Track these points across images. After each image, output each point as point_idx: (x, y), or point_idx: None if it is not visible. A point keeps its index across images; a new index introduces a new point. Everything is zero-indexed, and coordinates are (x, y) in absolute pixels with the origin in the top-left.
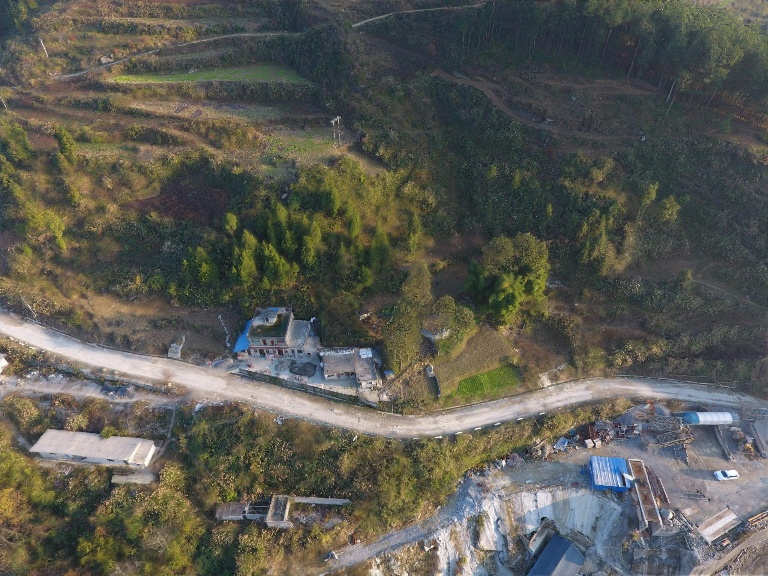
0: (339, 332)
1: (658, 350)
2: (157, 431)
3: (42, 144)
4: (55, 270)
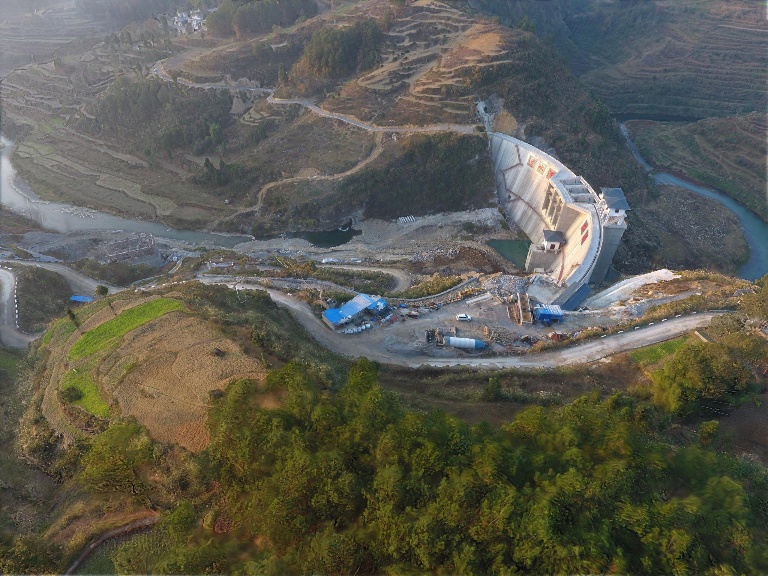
0: None
1: None
2: None
3: None
4: None
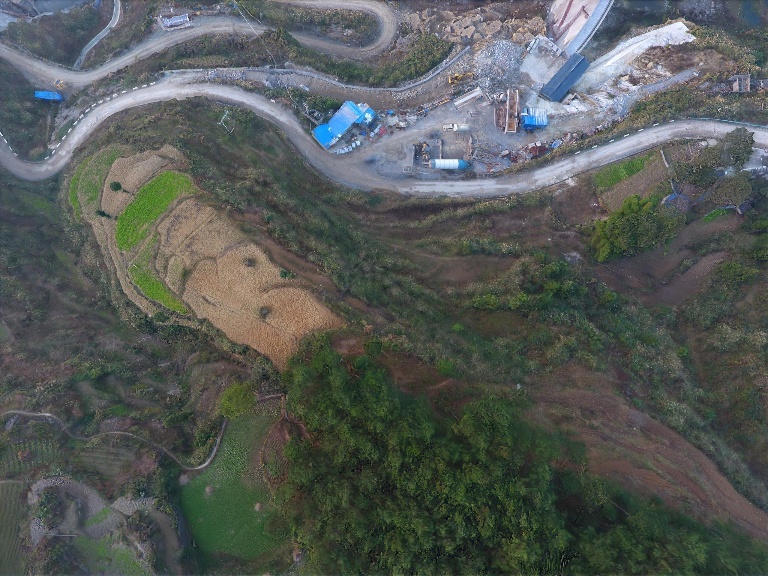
0: (760, 183)
1: (483, 204)
2: None
3: None
4: None
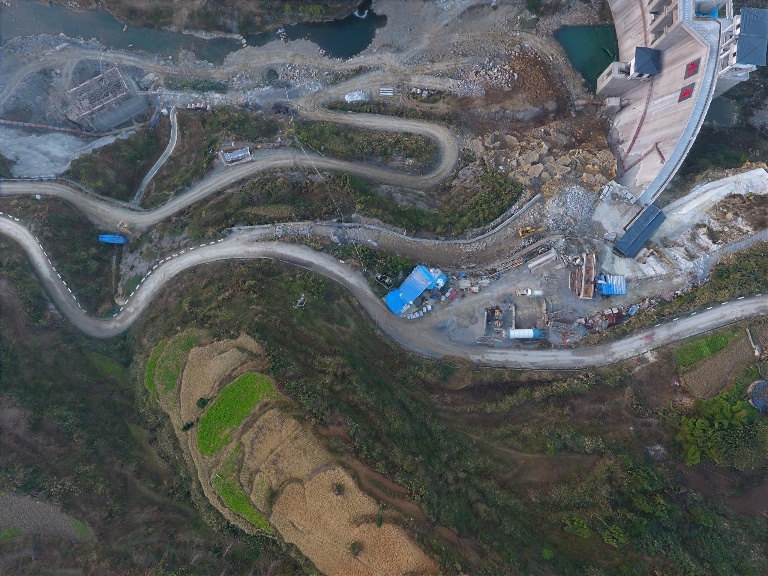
0: None
1: (561, 385)
2: None
3: None
4: None
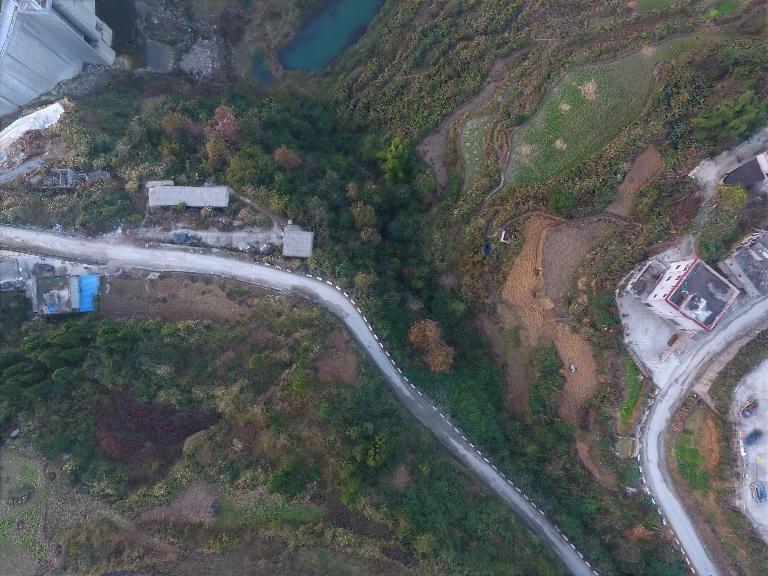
0: (2, 298)
1: None
2: (154, 216)
3: (336, 501)
4: (274, 336)
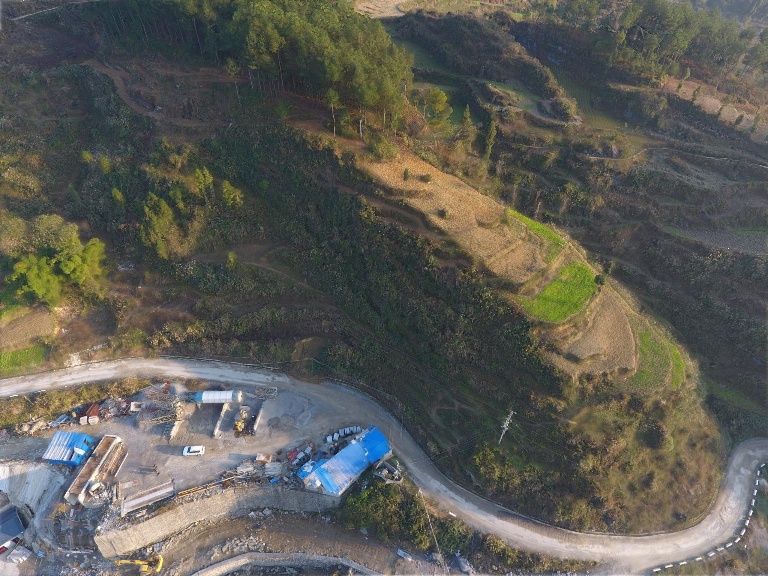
0: None
1: (195, 331)
2: None
3: None
4: None
